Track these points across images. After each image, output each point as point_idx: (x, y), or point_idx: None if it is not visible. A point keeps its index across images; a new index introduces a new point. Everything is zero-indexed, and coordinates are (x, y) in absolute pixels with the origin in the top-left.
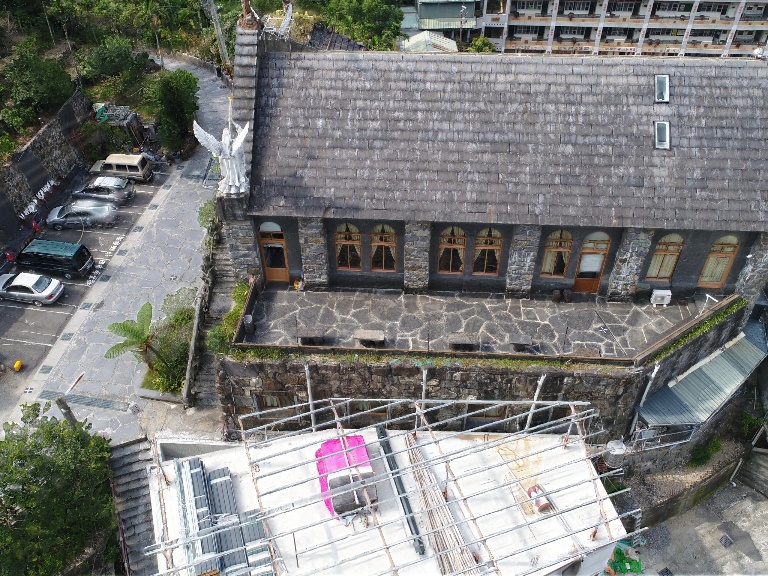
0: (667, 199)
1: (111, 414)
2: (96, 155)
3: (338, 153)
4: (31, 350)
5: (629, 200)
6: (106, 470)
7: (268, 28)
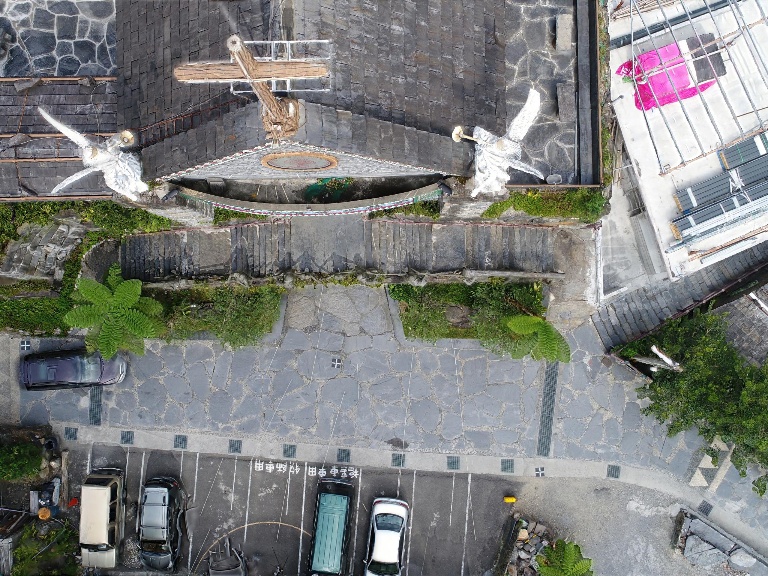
0: None
1: (566, 365)
2: (67, 574)
3: (434, 10)
4: (481, 497)
5: None
6: (699, 314)
7: (276, 86)
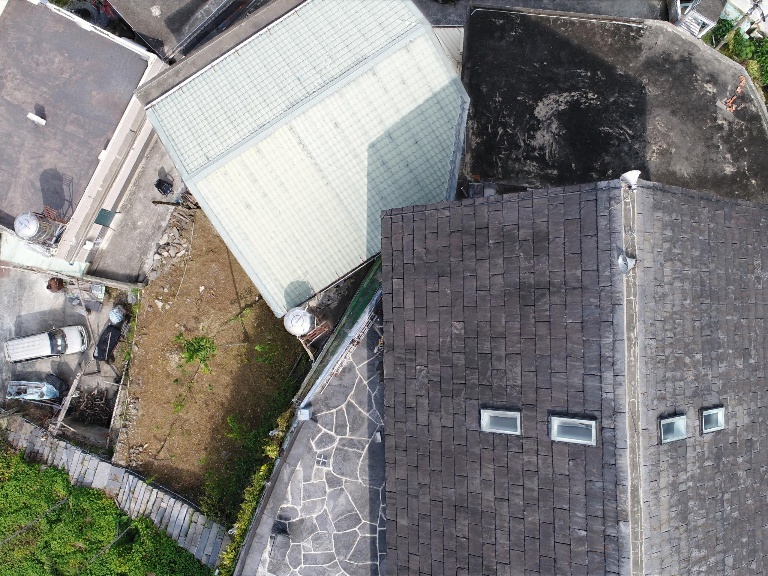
0: (759, 404)
1: None
2: None
3: None
4: None
5: (763, 458)
6: None
7: None
